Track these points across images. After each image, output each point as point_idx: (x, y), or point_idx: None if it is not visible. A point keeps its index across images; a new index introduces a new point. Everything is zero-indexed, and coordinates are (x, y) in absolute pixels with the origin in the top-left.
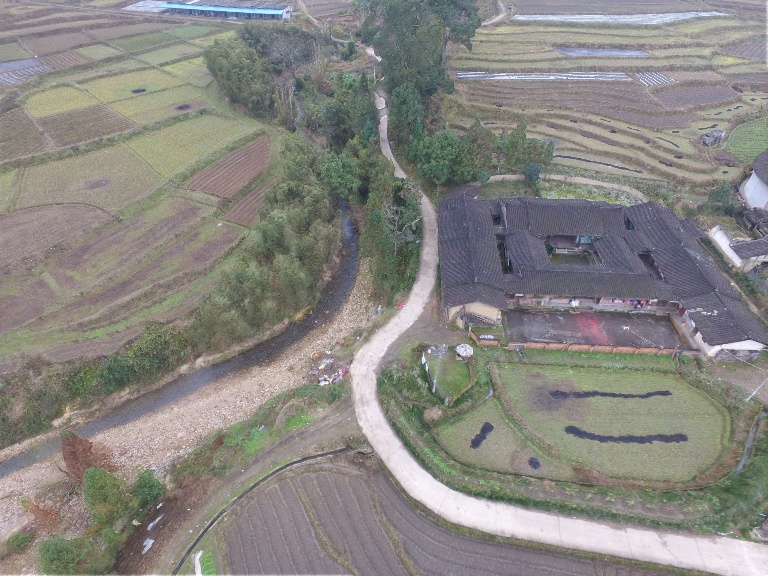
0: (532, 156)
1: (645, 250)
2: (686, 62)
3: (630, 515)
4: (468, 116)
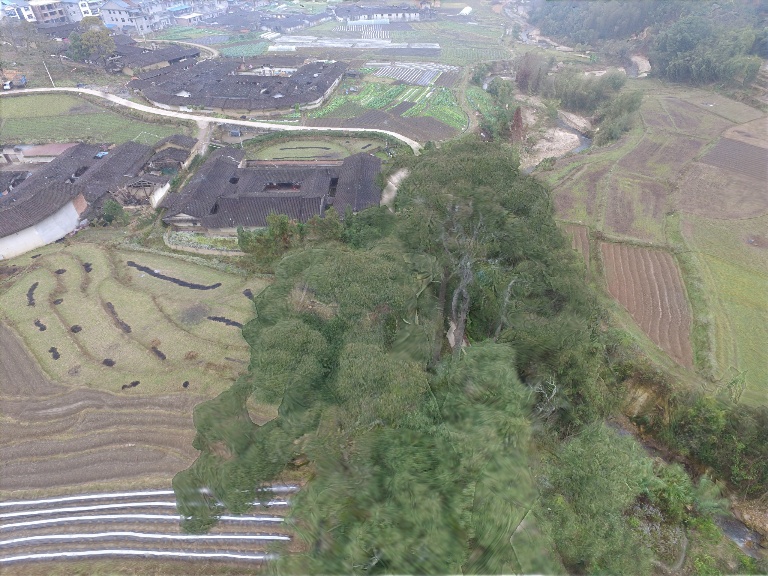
0: None
1: None
2: None
3: None
4: None
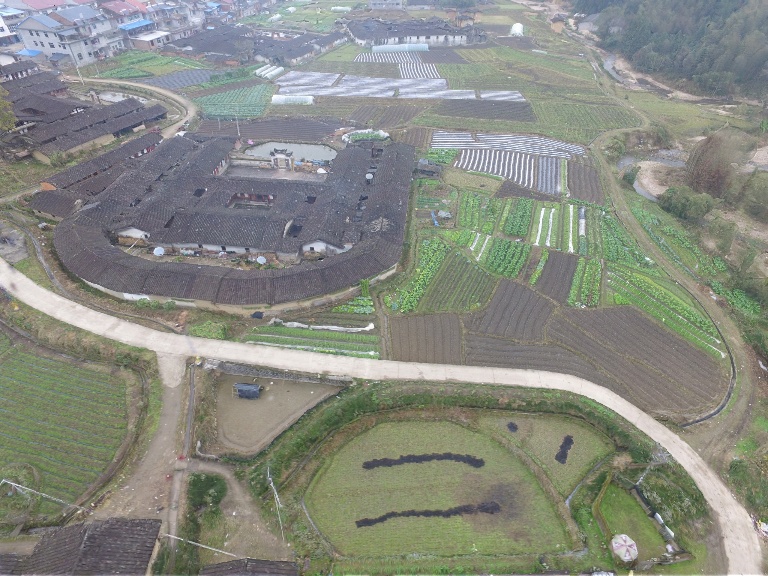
0: None
1: None
2: None
3: (443, 384)
4: None
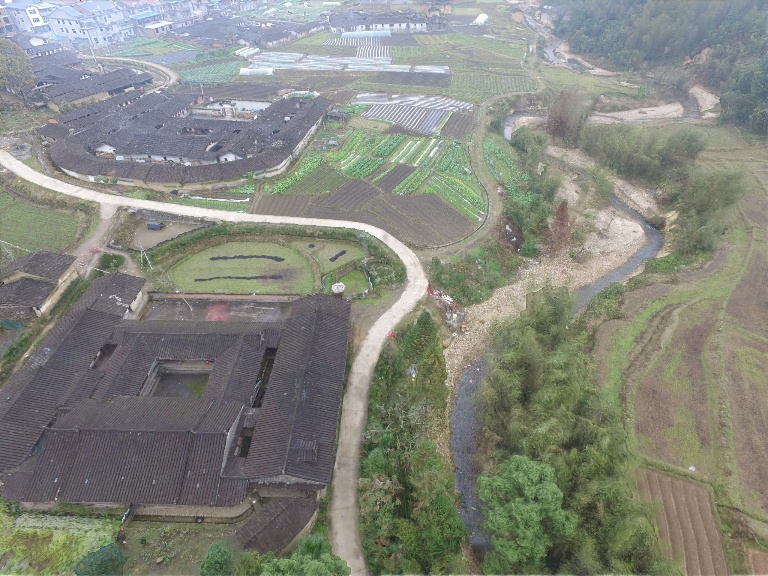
0: None
1: None
2: None
3: None
4: None
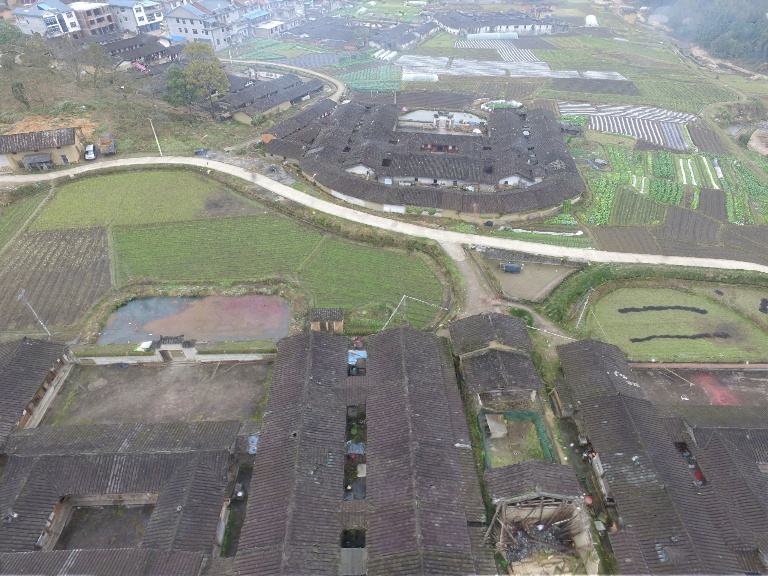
0: None
1: None
2: None
3: (659, 265)
4: None
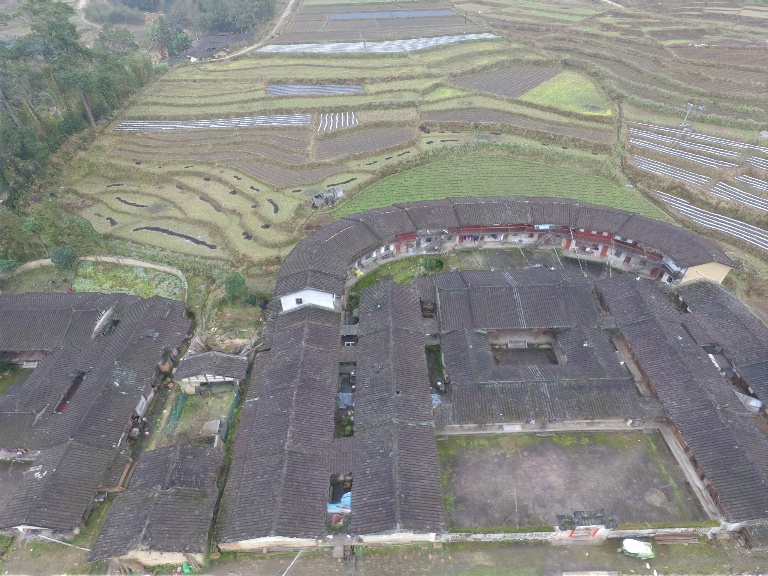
0: (71, 237)
1: (76, 371)
2: (393, 98)
3: None
4: (101, 176)
